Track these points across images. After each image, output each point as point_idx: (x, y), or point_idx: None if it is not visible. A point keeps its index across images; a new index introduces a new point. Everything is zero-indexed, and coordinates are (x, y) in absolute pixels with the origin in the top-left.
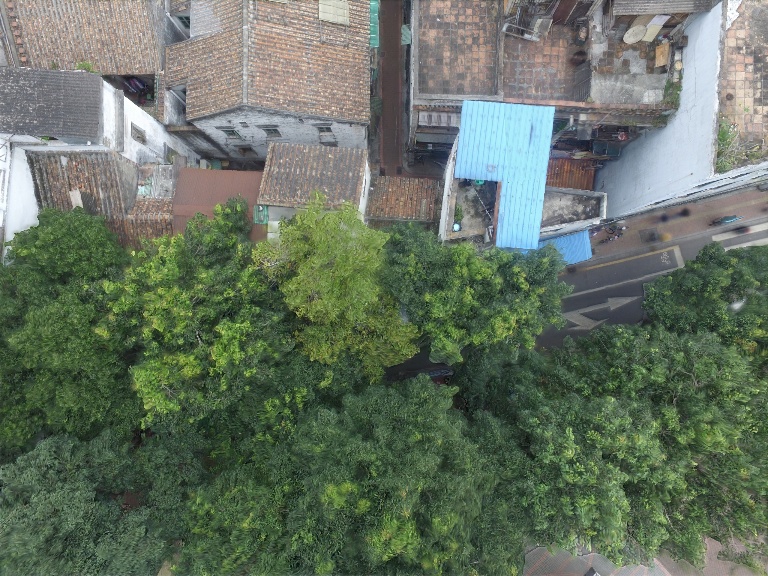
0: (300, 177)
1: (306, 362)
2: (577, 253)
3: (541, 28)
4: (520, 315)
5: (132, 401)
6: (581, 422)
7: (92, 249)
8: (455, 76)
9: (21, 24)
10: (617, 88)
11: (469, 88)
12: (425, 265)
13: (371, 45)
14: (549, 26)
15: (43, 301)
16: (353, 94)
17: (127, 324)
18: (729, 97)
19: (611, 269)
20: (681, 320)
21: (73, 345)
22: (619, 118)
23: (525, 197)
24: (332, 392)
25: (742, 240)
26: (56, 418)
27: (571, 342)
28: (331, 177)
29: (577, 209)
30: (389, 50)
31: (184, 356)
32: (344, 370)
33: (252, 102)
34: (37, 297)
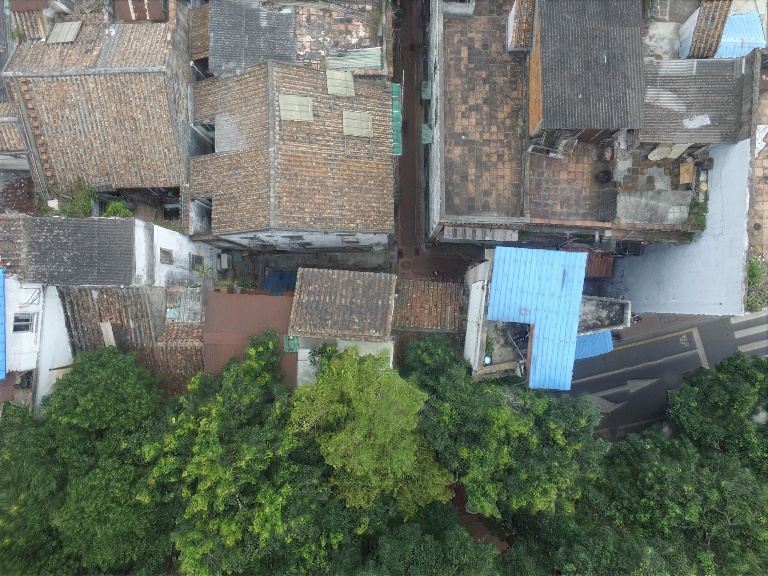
0: (330, 305)
1: (341, 502)
2: (598, 346)
3: (566, 147)
4: (560, 484)
5: (166, 536)
6: (617, 567)
7: (129, 403)
8: (480, 193)
9: (46, 141)
10: (642, 204)
11: (494, 205)
12: (460, 411)
13: (394, 153)
14: (574, 145)
15: (82, 461)
16: (377, 204)
17: (165, 481)
18: (757, 227)
19: (630, 351)
20: (708, 436)
21: (115, 515)
22: (644, 234)
23: (558, 339)
24: (366, 530)
25: (760, 322)
26: (92, 560)
27: (598, 455)
28: (361, 305)
29: (601, 314)
30: (405, 131)
31: (225, 523)
32: (379, 510)
33: (279, 224)
34: (77, 459)
